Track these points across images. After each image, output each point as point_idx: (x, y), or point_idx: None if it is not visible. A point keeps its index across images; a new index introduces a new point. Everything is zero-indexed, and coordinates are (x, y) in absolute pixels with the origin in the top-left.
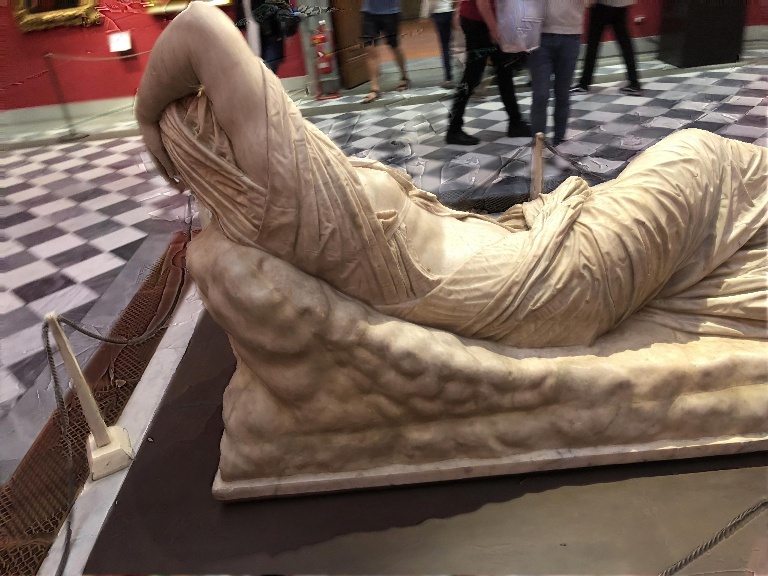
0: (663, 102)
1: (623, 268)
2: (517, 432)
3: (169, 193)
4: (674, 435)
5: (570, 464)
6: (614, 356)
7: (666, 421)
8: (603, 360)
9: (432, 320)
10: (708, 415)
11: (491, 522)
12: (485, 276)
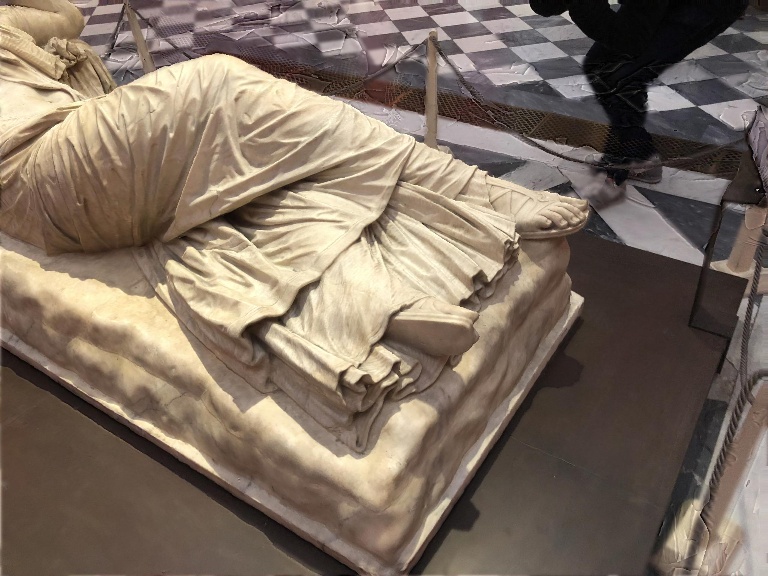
0: None
1: (54, 187)
2: None
3: (82, 5)
4: (78, 373)
5: (15, 352)
6: (50, 273)
7: (66, 355)
8: (37, 271)
9: None
10: (91, 369)
11: None
12: None
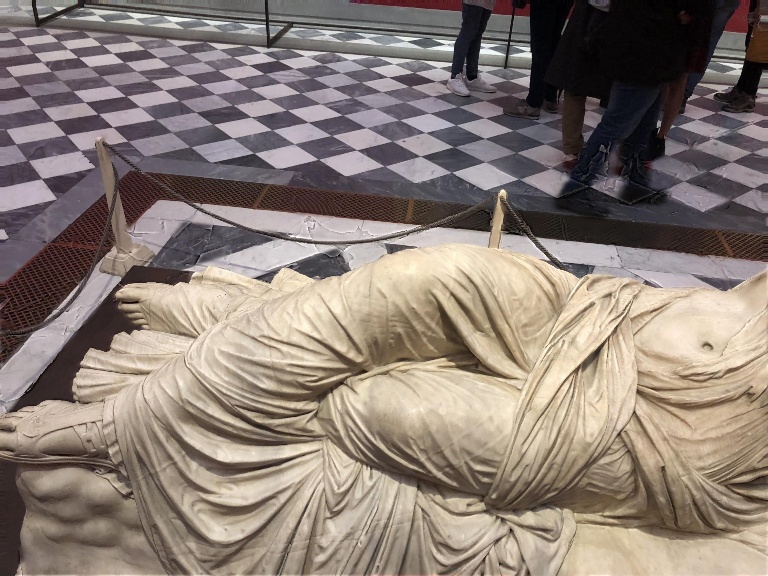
0: None
1: None
2: None
3: None
4: None
5: None
6: None
7: None
8: None
9: None
10: None
11: None
12: None
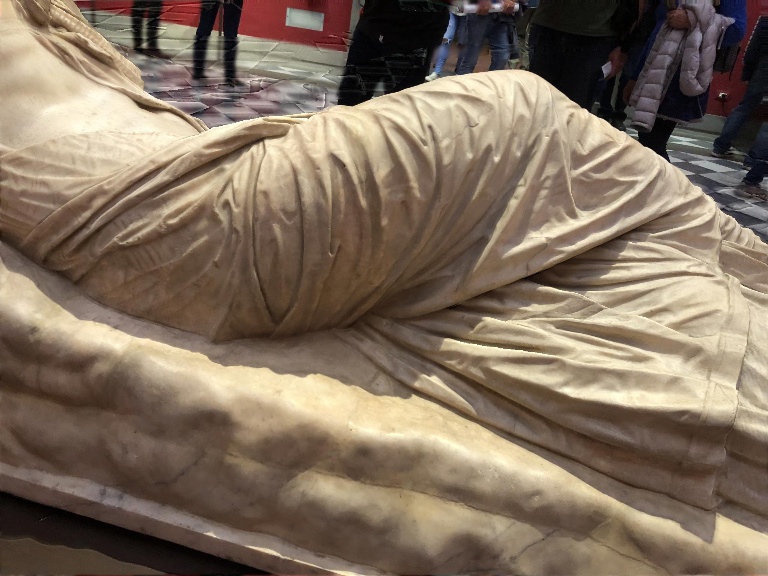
0: (712, 183)
1: (287, 228)
2: (41, 434)
3: None
4: (287, 534)
5: (113, 517)
6: (236, 369)
7: (274, 504)
8: (211, 367)
9: None
10: (343, 520)
11: None
12: (66, 168)
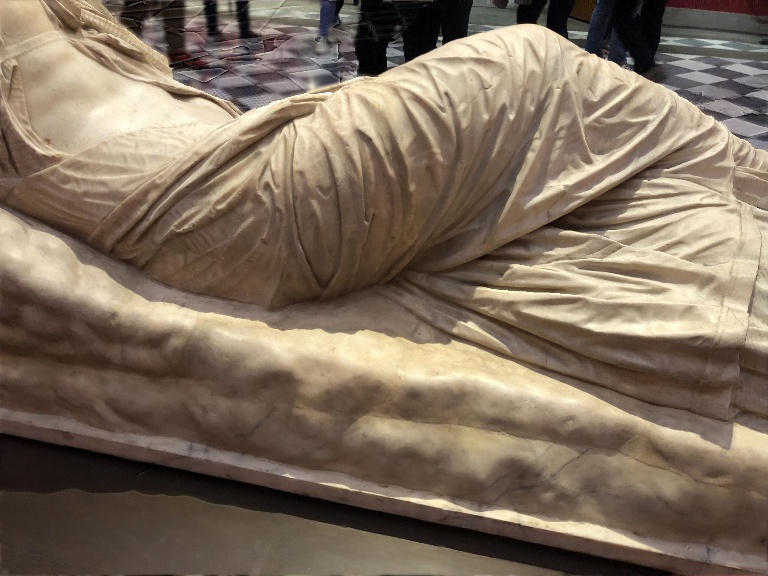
0: (739, 87)
1: (324, 202)
2: (131, 403)
3: None
4: (353, 470)
5: (202, 468)
6: (292, 332)
7: (339, 446)
8: (271, 333)
9: (49, 215)
10: (400, 455)
11: (54, 515)
12: (120, 167)
